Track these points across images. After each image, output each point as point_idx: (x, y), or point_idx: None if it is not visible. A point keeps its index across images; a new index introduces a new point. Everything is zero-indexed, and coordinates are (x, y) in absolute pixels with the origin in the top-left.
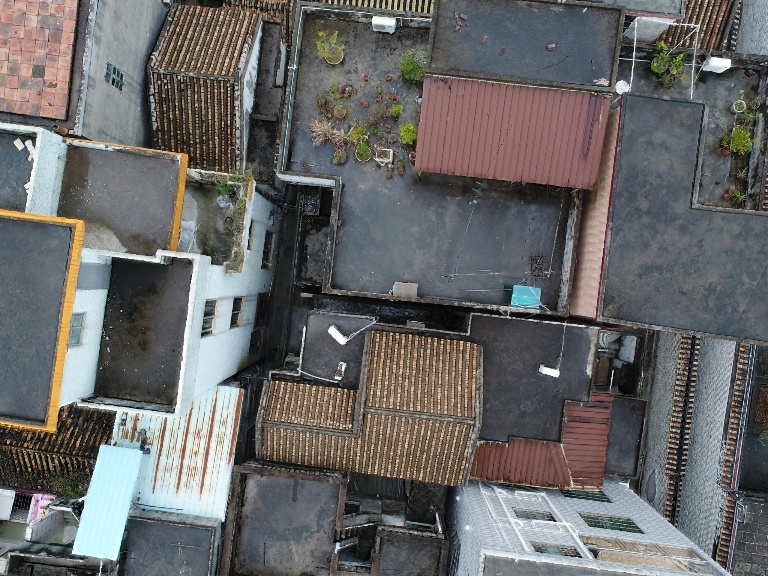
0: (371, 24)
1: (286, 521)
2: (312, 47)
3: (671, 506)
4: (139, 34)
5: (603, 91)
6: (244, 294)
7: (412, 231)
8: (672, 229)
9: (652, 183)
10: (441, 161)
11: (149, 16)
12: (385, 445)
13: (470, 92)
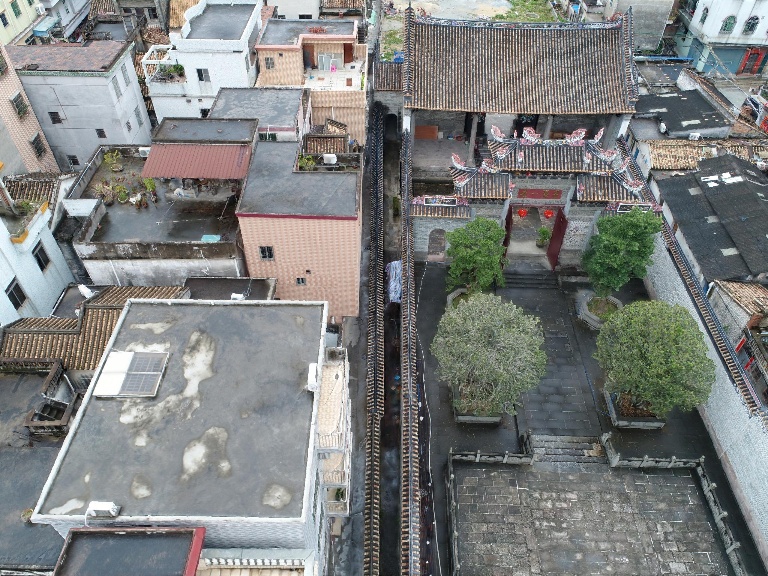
0: (142, 158)
1: (1, 407)
2: (106, 167)
3: (370, 431)
4: (6, 167)
5: (246, 142)
6: (28, 294)
7: (146, 228)
8: (282, 180)
9: (271, 166)
10: (157, 173)
11: (16, 167)
12: (101, 339)
13: (176, 148)
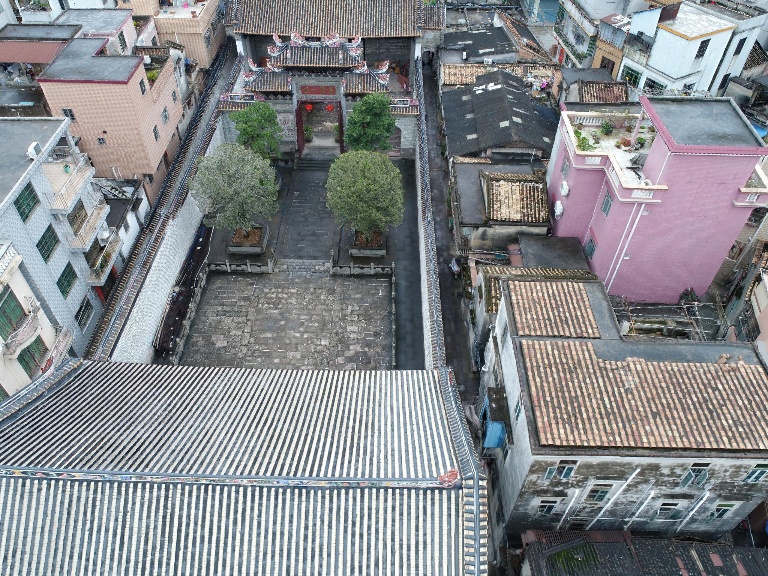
0: None
1: None
2: None
3: None
4: None
5: (66, 39)
6: None
7: None
8: None
9: None
10: None
11: None
12: None
13: None
